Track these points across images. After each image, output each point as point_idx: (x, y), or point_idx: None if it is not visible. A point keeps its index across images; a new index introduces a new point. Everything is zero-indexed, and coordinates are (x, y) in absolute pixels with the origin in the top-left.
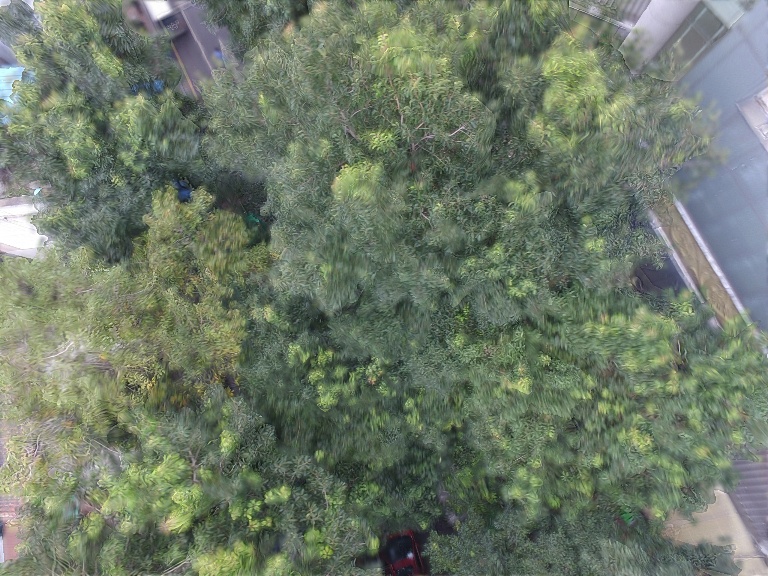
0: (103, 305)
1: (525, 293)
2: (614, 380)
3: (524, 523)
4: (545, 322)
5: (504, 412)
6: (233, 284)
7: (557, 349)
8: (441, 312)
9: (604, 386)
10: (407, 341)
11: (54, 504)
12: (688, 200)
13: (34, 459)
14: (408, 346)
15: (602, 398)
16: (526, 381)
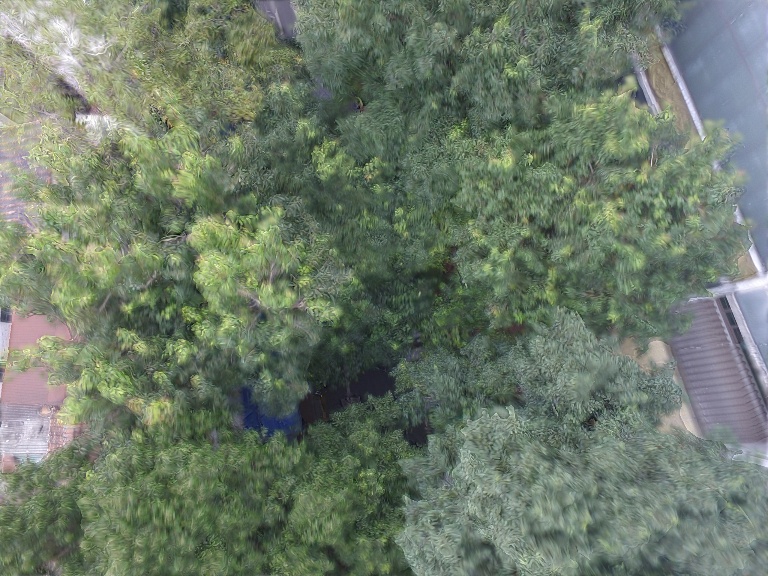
0: (141, 36)
1: (517, 71)
2: (587, 185)
3: (487, 345)
4: (533, 130)
5: (483, 205)
6: (255, 77)
7: (540, 157)
8: (440, 121)
9: (577, 190)
10: (405, 148)
11: (75, 181)
12: (689, 72)
13: (63, 142)
14: (405, 152)
15: (574, 199)
16: (505, 155)
